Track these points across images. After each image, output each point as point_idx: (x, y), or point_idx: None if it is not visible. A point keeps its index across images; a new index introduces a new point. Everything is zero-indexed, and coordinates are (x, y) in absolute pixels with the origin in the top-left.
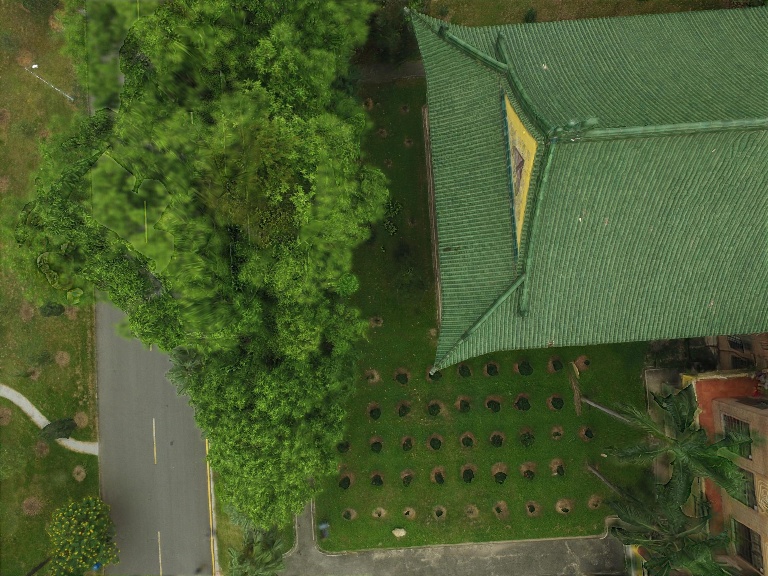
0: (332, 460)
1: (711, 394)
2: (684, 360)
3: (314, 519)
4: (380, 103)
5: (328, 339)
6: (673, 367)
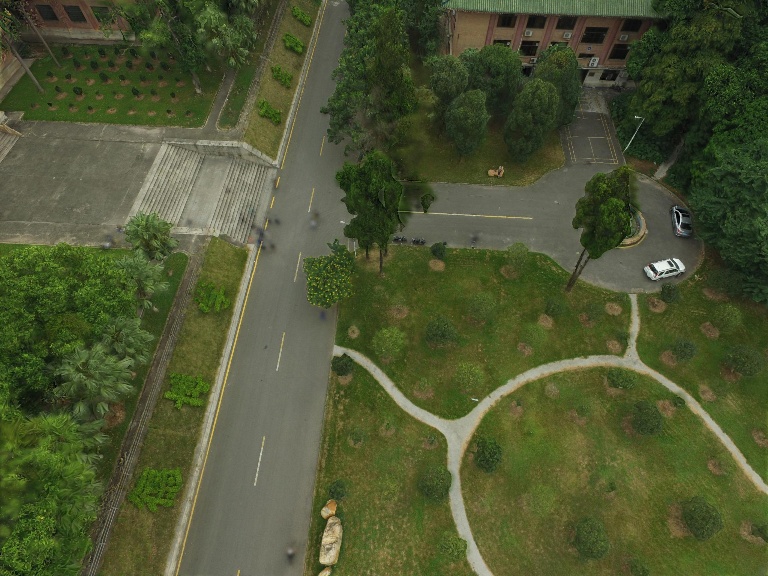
0: None
1: None
2: None
3: None
4: None
5: None
6: None
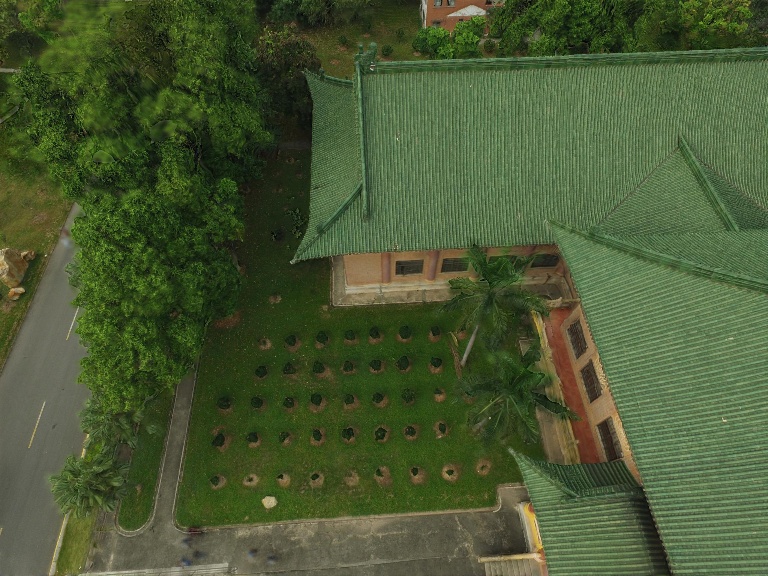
0: (191, 328)
1: (558, 321)
2: None
3: (179, 489)
4: (299, 160)
5: (204, 218)
6: None
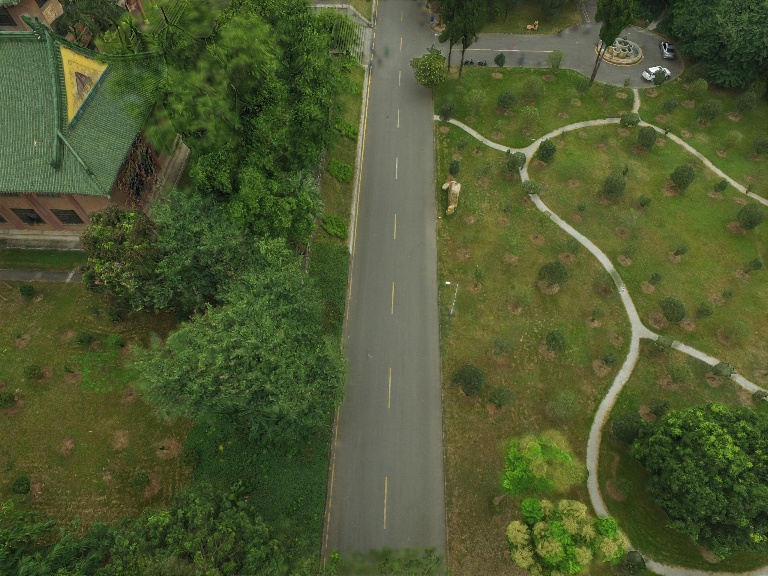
0: None
1: None
2: None
3: None
4: None
5: None
6: None
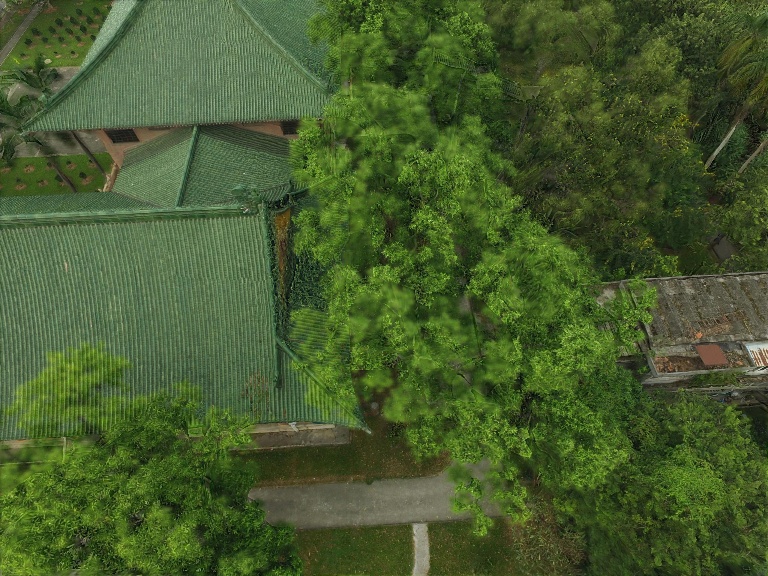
0: None
1: None
2: None
3: (5, 60)
4: None
5: None
6: None
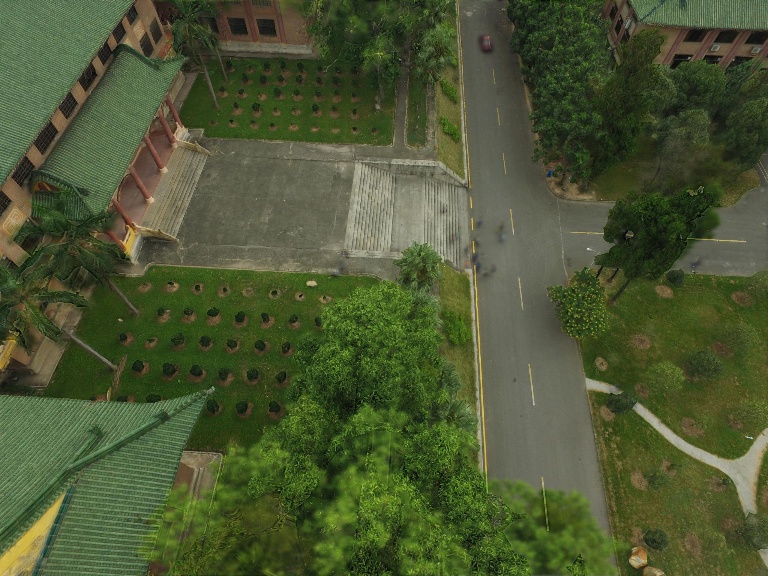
0: None
1: None
2: (5, 392)
3: None
4: None
5: None
6: (19, 387)
